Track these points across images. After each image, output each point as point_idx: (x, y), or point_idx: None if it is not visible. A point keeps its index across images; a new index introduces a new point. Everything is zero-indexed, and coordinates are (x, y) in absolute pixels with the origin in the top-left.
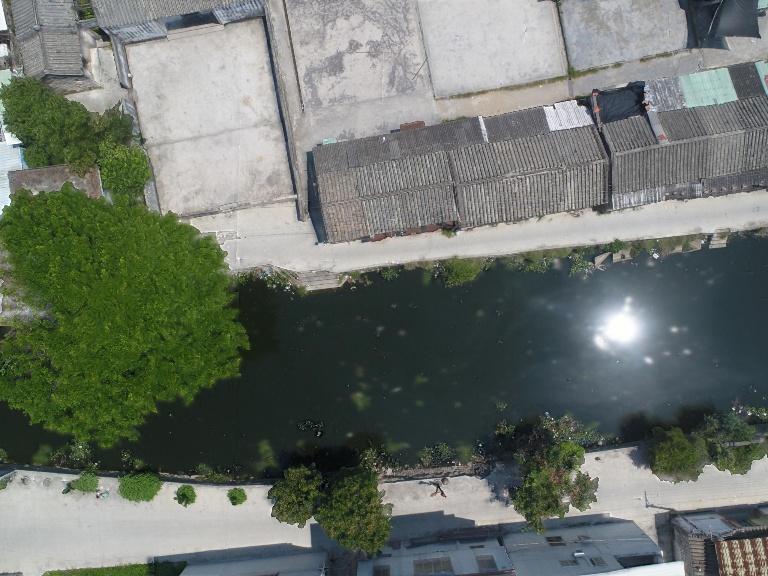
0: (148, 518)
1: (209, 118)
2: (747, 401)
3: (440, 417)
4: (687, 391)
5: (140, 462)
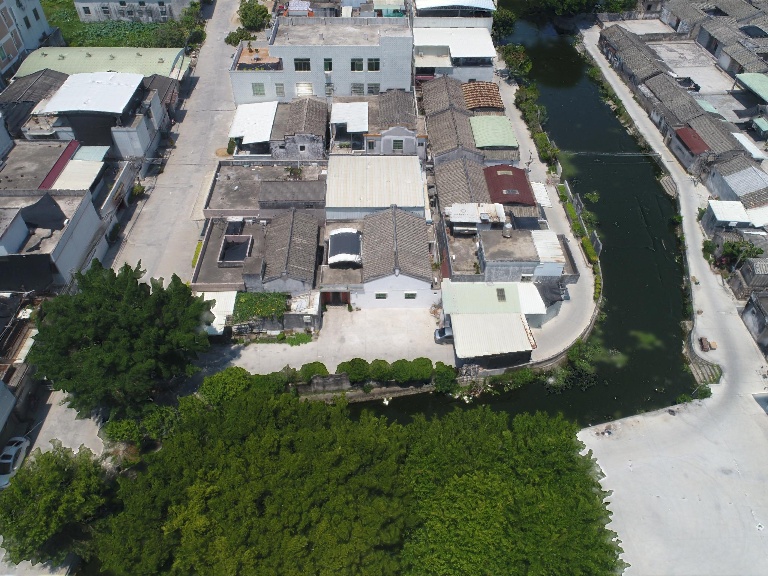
0: None
1: None
2: (550, 136)
3: None
4: (552, 122)
5: None
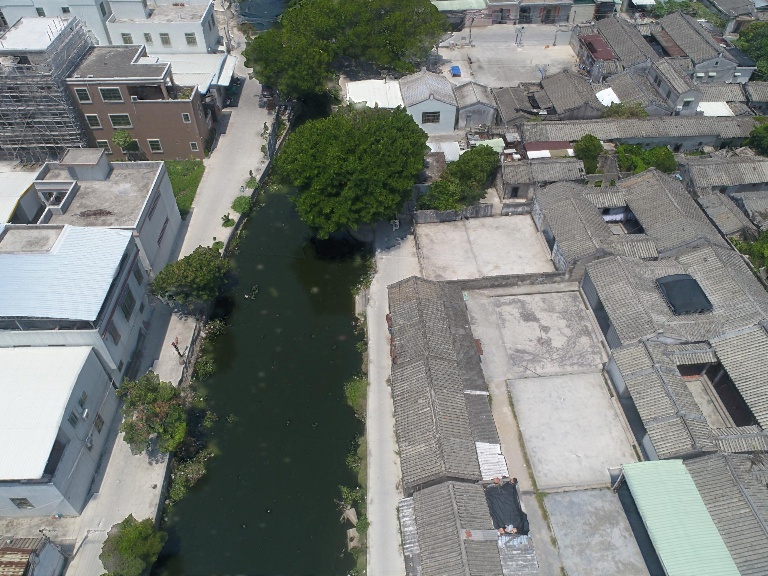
0: (220, 206)
1: (484, 249)
2: None
3: (235, 372)
4: None
5: (257, 210)
